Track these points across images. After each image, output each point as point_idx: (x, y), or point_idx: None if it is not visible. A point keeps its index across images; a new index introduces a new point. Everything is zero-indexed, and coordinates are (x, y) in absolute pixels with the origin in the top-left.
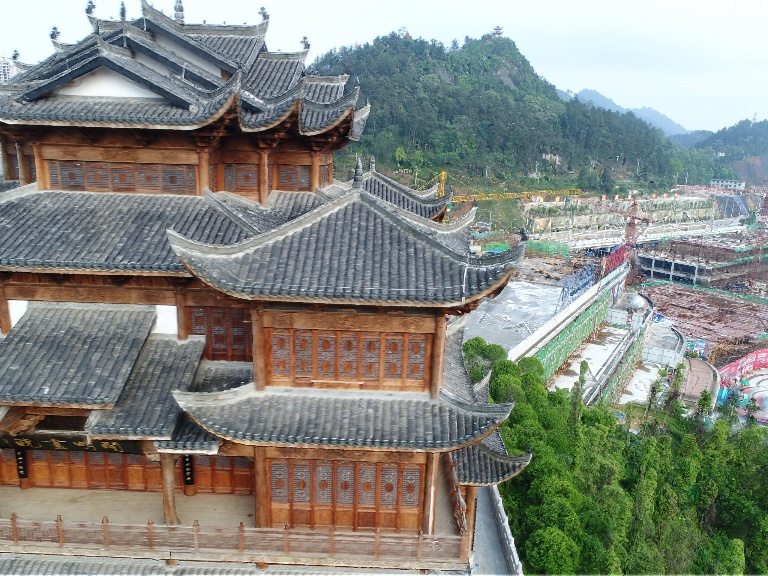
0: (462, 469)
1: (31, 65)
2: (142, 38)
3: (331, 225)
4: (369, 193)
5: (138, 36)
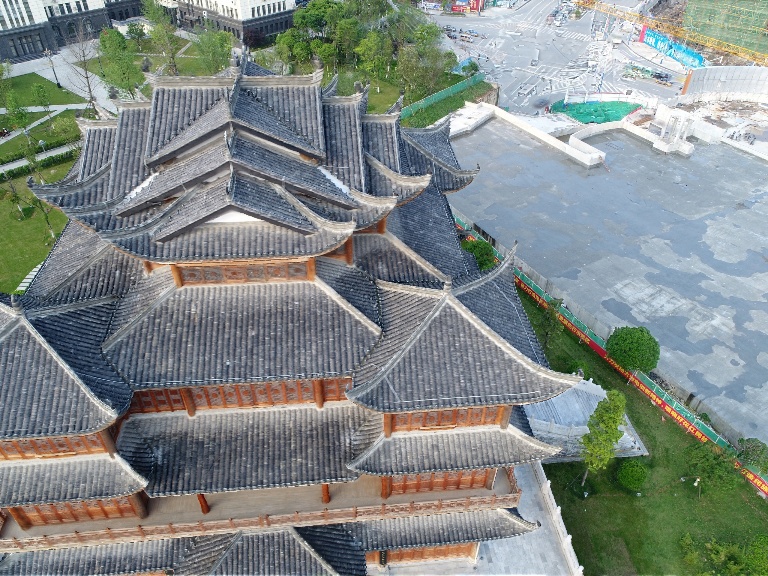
0: (184, 575)
1: None
2: (144, 108)
3: (2, 322)
4: (27, 322)
5: (138, 107)
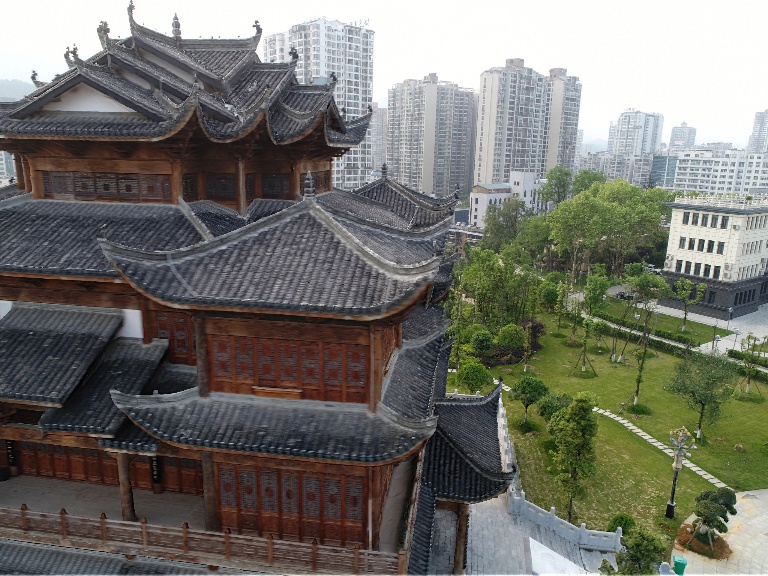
0: None
1: (320, 86)
2: None
3: None
4: None
5: None
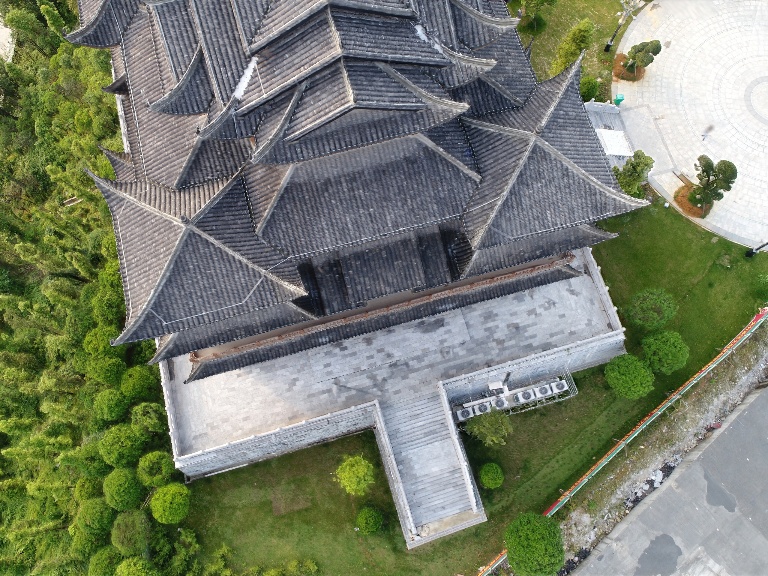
0: None
1: None
2: None
3: None
4: None
5: None
